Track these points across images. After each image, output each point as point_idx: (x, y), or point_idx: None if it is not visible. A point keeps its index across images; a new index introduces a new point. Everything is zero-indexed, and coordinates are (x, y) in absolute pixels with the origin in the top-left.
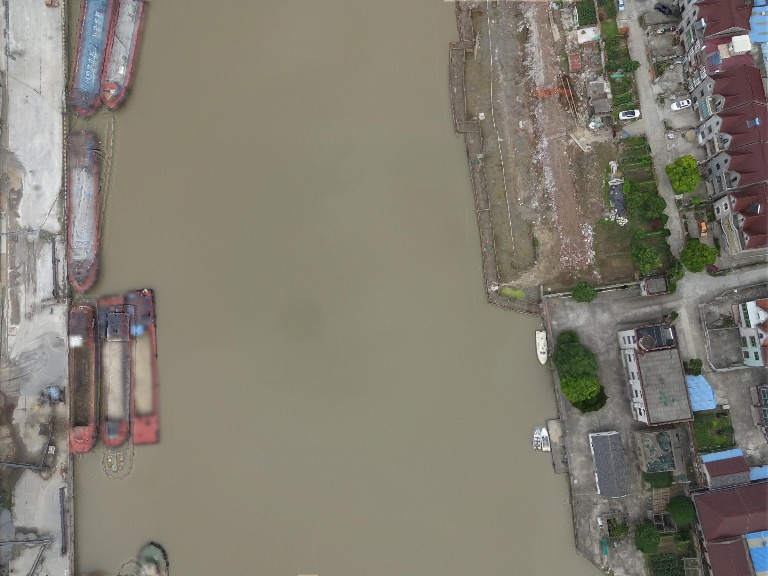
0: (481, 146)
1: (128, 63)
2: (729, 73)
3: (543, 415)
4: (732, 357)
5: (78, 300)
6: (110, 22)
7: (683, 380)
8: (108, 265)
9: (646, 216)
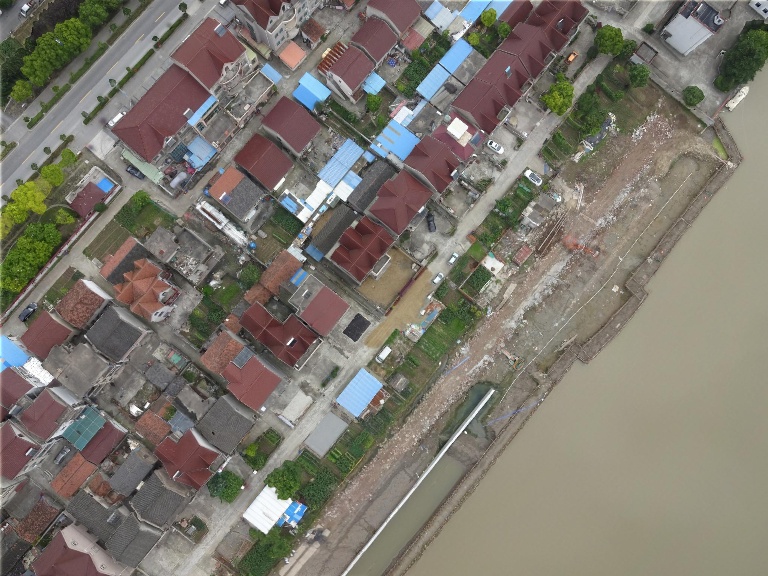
0: (642, 267)
1: None
2: (480, 121)
3: None
4: None
5: None
6: None
7: None
8: None
9: None
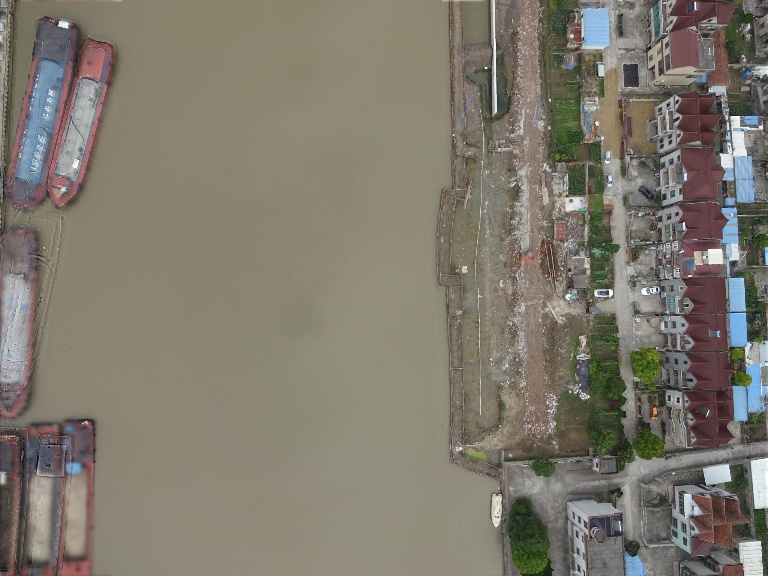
0: (461, 302)
1: (84, 155)
2: (700, 281)
3: (490, 575)
4: (662, 533)
5: (5, 428)
6: (65, 102)
7: (623, 565)
8: (43, 387)
9: (607, 396)
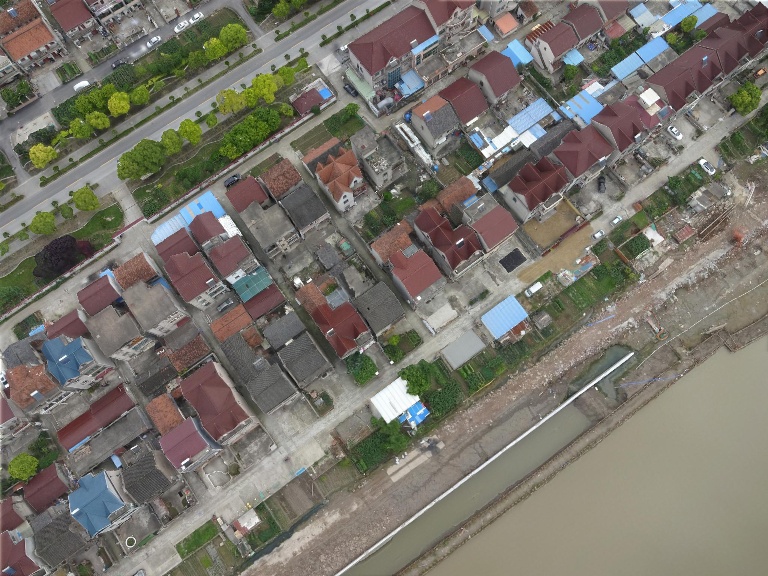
0: None
1: None
2: (670, 97)
3: None
4: None
5: None
6: None
7: None
8: None
9: None
